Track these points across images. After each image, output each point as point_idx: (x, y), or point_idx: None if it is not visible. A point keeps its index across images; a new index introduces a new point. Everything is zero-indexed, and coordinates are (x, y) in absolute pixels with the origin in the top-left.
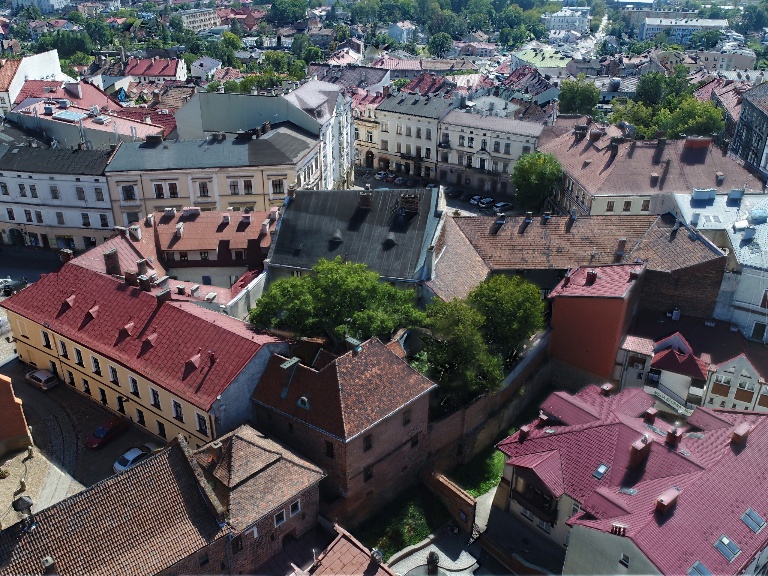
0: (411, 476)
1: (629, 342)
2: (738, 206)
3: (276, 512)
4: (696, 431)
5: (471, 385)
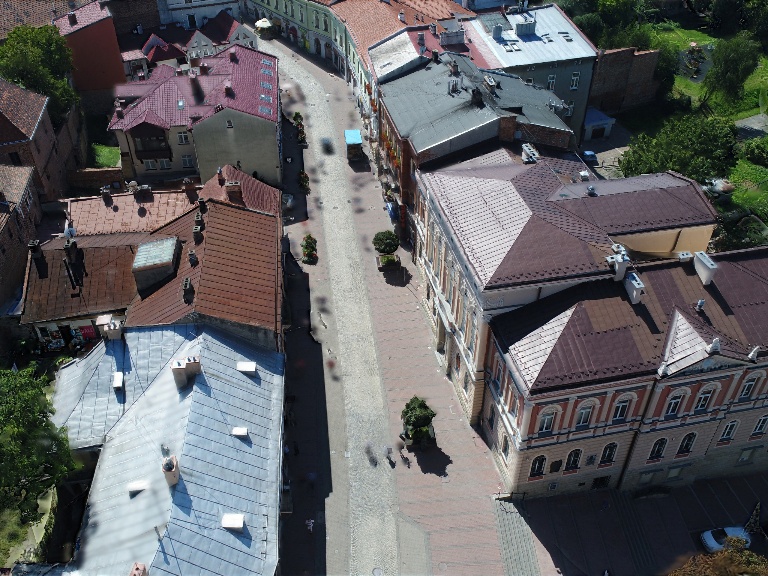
0: (65, 180)
1: (125, 56)
2: None
3: (24, 198)
4: (208, 70)
5: (62, 101)
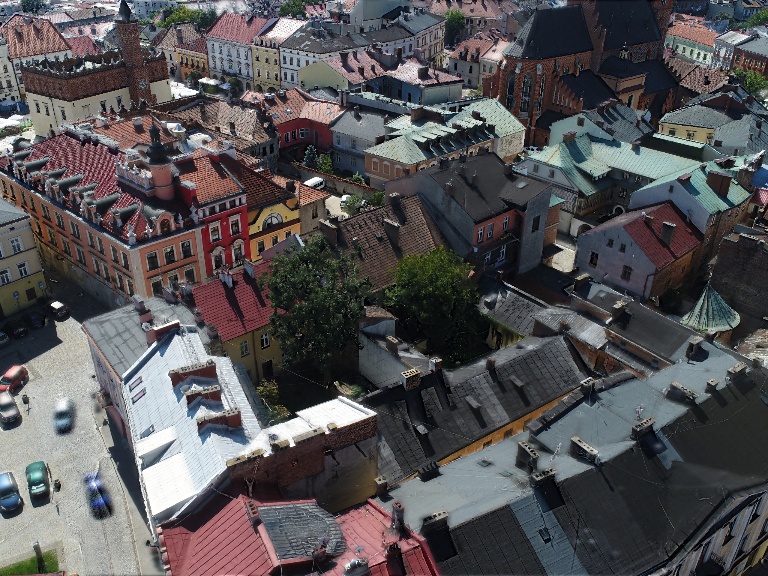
0: None
1: None
2: (558, 4)
3: None
4: None
5: None
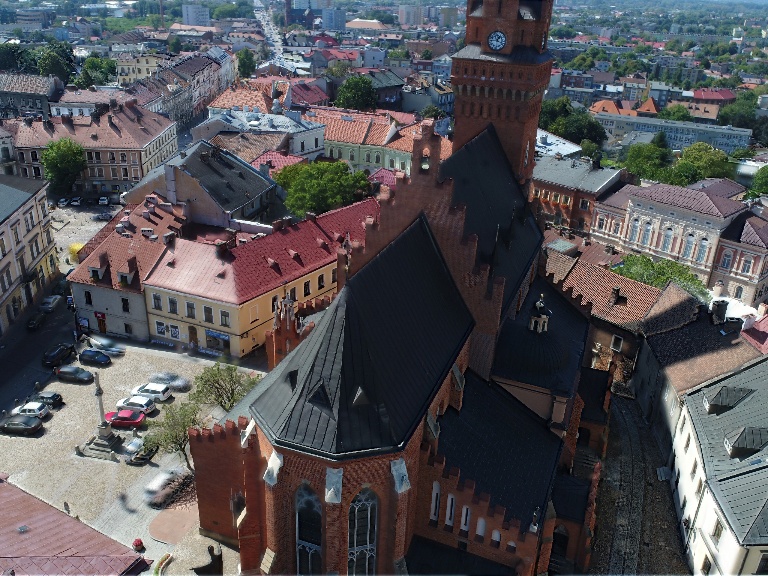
0: None
1: None
2: (235, 118)
3: None
4: None
5: None
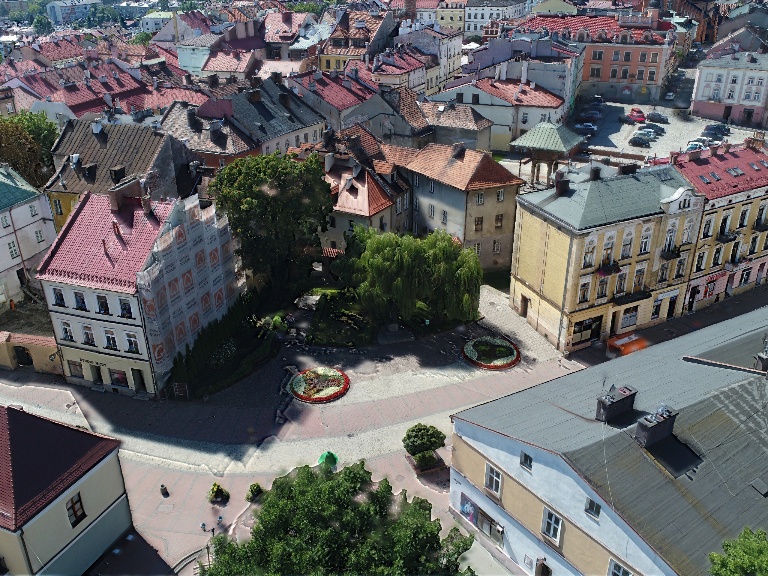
0: None
1: None
2: None
3: None
4: None
5: None
